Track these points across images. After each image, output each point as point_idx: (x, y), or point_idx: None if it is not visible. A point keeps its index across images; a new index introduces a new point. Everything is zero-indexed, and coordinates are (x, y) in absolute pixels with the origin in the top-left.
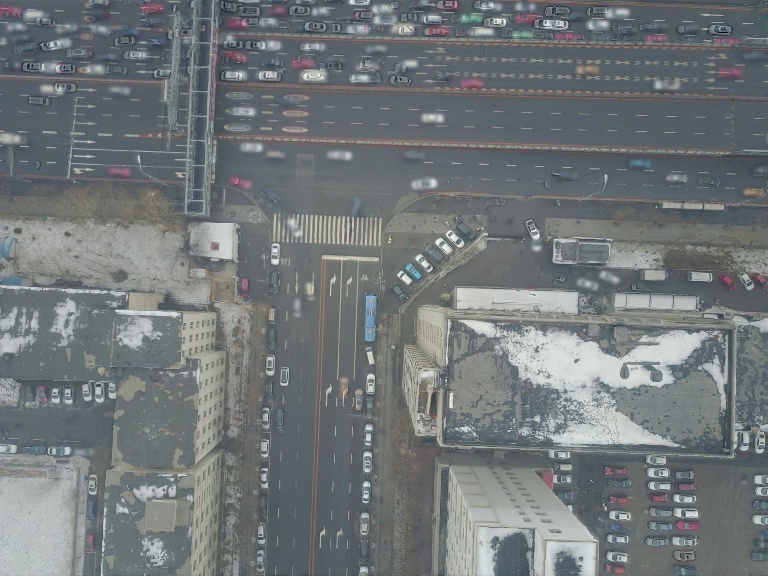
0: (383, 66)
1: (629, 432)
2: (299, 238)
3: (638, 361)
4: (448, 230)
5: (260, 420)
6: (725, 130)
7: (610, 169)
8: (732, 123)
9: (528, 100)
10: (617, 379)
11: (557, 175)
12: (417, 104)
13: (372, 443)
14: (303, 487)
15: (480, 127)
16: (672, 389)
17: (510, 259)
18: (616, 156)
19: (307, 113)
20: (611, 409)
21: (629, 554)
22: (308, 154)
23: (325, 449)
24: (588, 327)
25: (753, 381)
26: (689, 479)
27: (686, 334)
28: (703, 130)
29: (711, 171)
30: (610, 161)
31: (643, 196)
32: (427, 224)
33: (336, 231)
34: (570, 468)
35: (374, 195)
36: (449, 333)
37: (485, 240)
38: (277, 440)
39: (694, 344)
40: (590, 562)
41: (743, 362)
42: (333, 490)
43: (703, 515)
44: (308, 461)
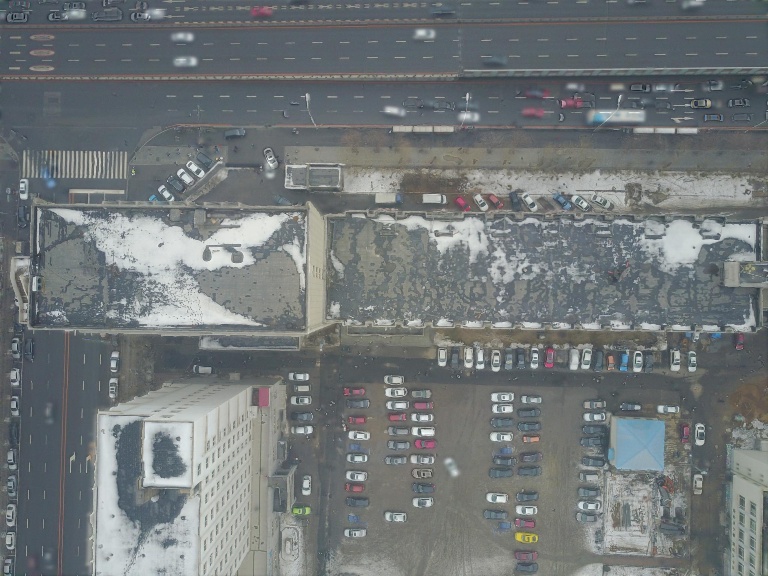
0: (125, 4)
1: (212, 312)
2: (48, 173)
3: (220, 244)
4: (188, 161)
5: (11, 350)
6: (453, 53)
7: (347, 97)
8: (459, 46)
9: (263, 31)
10: (199, 261)
11: (295, 104)
12: (157, 39)
13: (118, 370)
14: (54, 414)
15: (217, 59)
16: (252, 270)
17: (250, 188)
18: (353, 84)
19: (53, 52)
20: (194, 290)
21: (370, 473)
22: (55, 92)
23: (74, 377)
24: (170, 212)
25: (401, 278)
26: (426, 398)
27: (267, 216)
28: (432, 54)
29: (446, 95)
30: (347, 89)
31: (380, 122)
32: (170, 156)
33: (84, 166)
34: (307, 389)
35: (119, 130)
36: (39, 222)
37: (226, 170)
38: (27, 369)
39: (274, 226)
40: (187, 442)
41: (391, 260)
42: (82, 416)
43: (442, 434)
44: (58, 389)
